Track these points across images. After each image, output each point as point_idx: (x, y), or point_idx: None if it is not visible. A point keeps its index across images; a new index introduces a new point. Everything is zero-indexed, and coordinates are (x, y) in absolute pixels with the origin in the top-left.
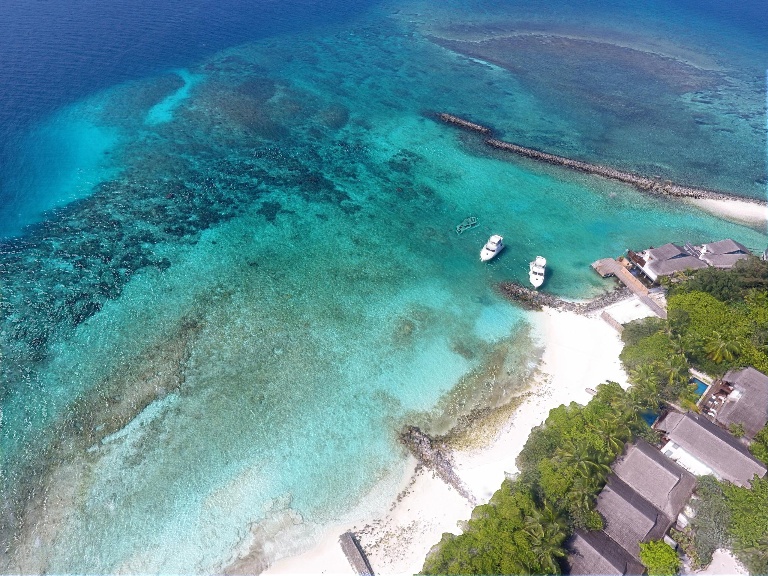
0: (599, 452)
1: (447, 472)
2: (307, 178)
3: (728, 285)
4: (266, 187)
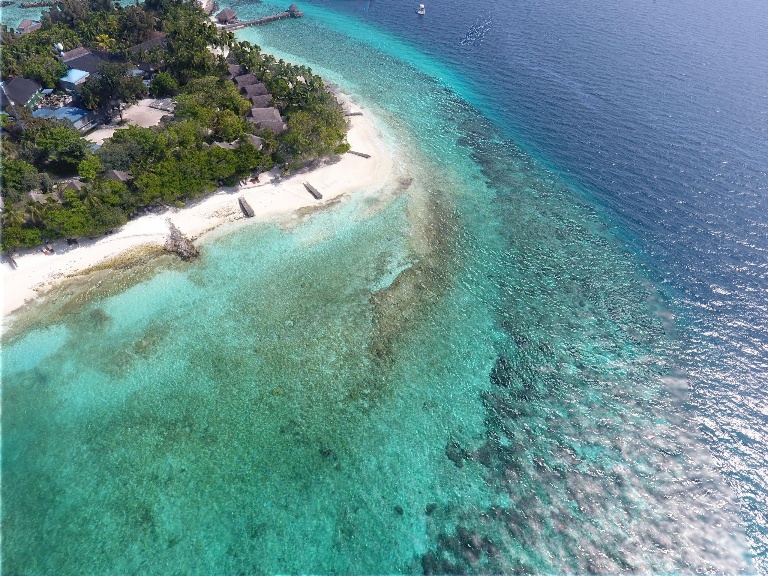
0: None
1: (176, 232)
2: None
3: None
4: None
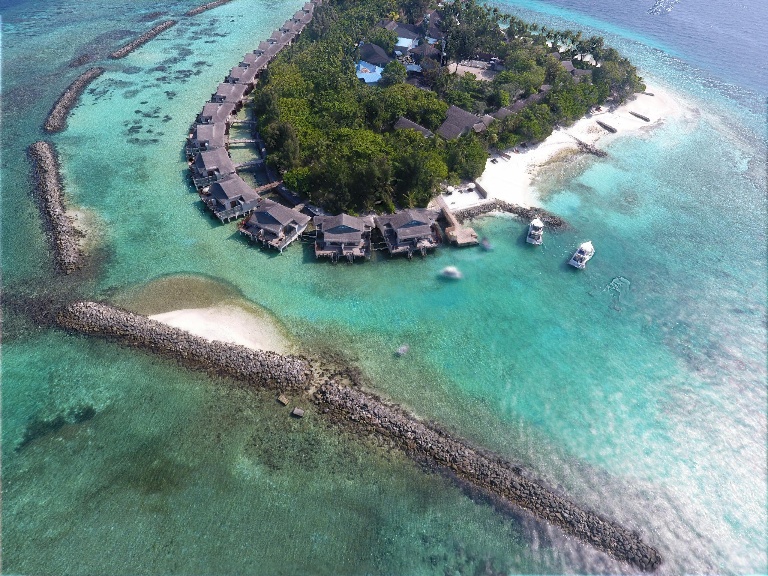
0: None
1: None
2: None
3: None
4: None
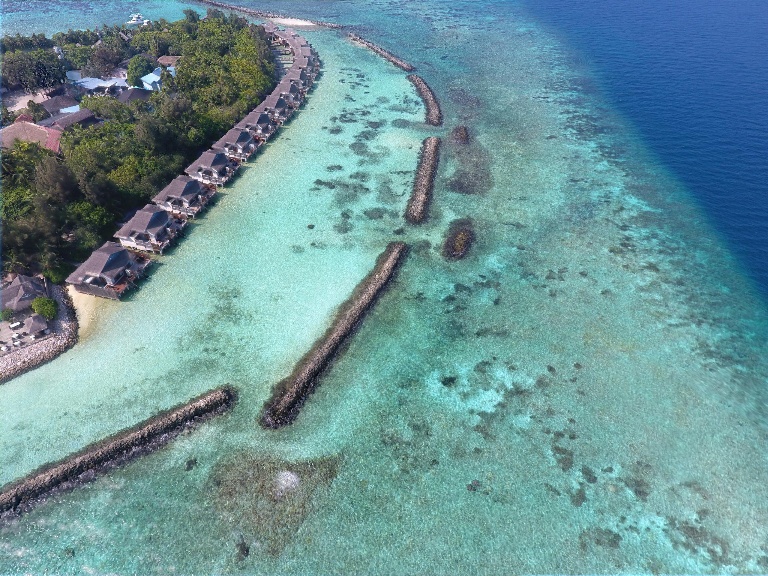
0: (76, 32)
1: None
2: (78, 3)
3: (191, 14)
4: (54, 5)
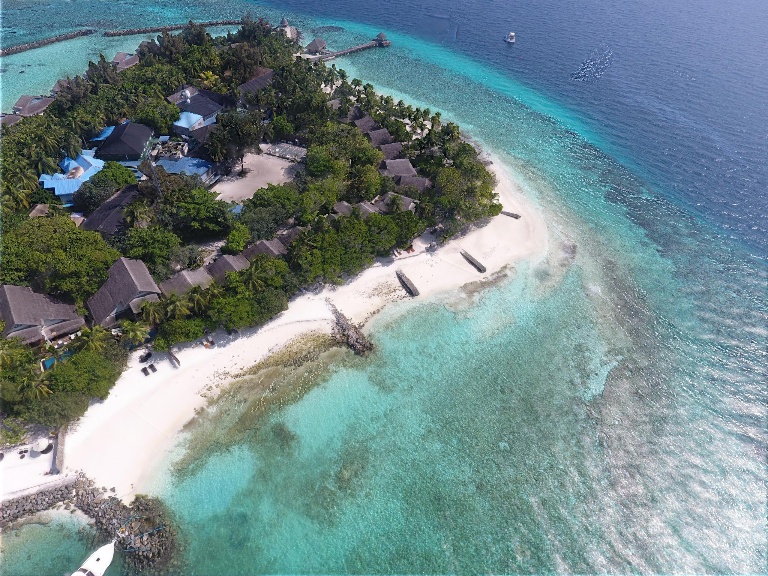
0: (237, 272)
1: (341, 317)
2: None
3: None
4: None
